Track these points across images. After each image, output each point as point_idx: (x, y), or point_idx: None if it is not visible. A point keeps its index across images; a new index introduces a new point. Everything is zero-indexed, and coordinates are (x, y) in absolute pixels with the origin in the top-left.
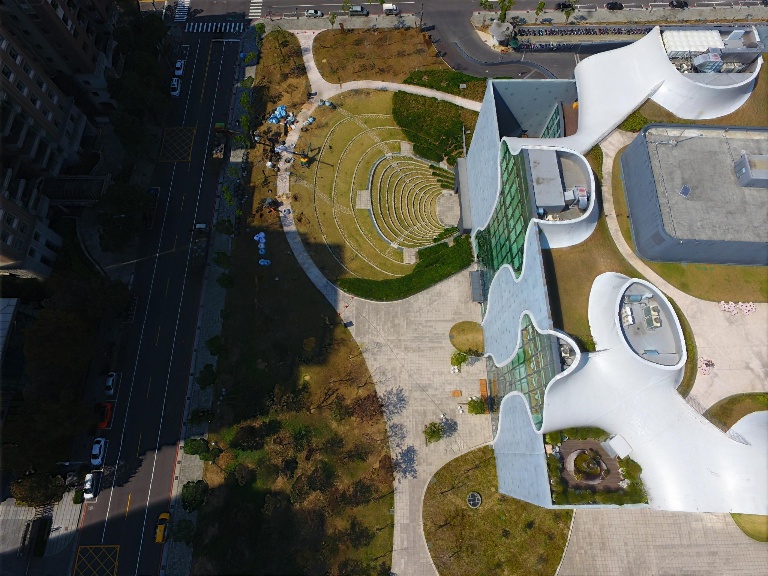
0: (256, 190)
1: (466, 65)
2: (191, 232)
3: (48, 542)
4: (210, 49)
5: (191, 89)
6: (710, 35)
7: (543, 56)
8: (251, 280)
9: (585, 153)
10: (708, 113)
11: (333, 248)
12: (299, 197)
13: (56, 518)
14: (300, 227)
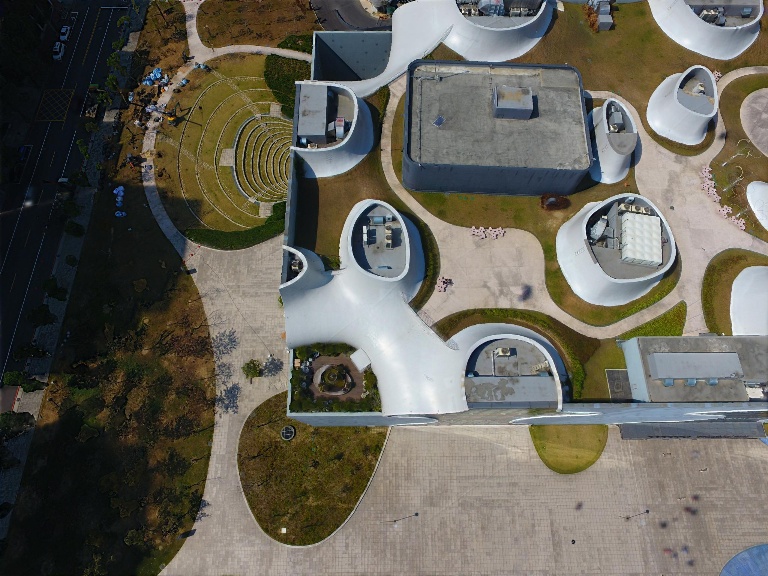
0: (123, 147)
1: None
2: (57, 187)
3: None
4: (98, 16)
5: (75, 53)
6: None
7: None
8: (107, 231)
9: (372, 93)
10: (496, 56)
11: (191, 202)
12: (163, 154)
13: None
14: (159, 181)
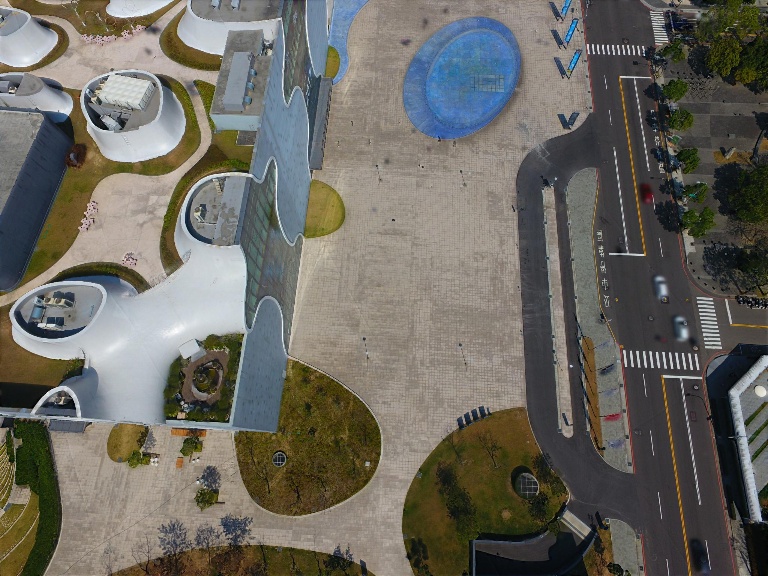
0: None
1: None
2: None
3: None
4: None
5: None
6: None
7: None
8: None
9: None
10: None
11: None
12: None
13: None
14: None
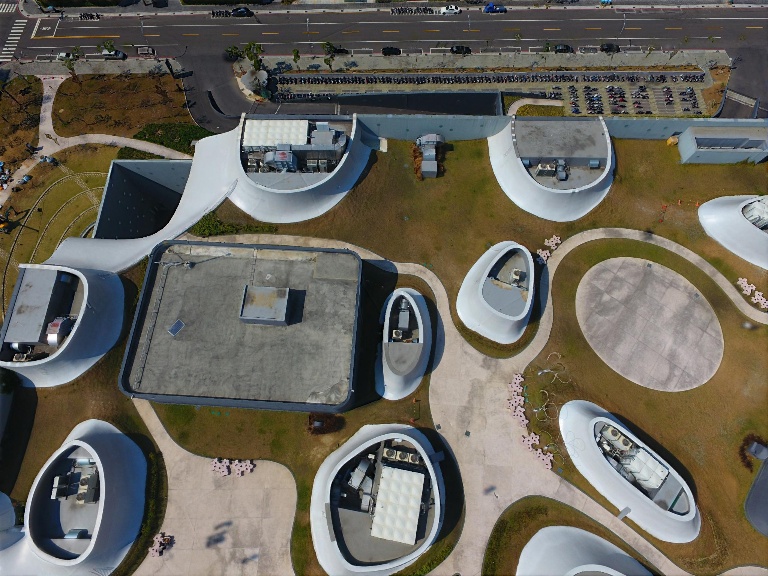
0: None
1: (211, 117)
2: None
3: None
4: None
5: None
6: (295, 126)
7: (300, 107)
8: None
9: (135, 263)
10: (291, 216)
11: None
12: None
13: None
14: None
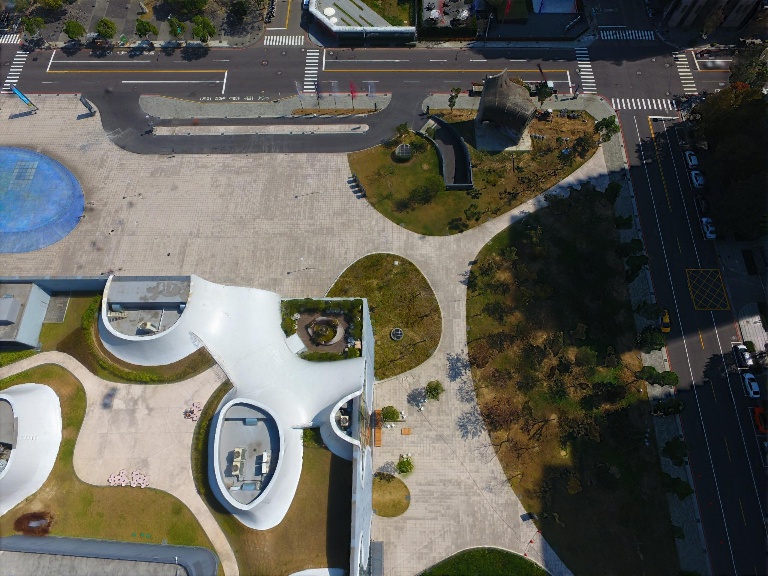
0: None
1: None
2: None
3: (759, 313)
4: None
5: None
6: None
7: None
8: None
9: None
10: None
11: None
12: None
13: (761, 330)
14: None
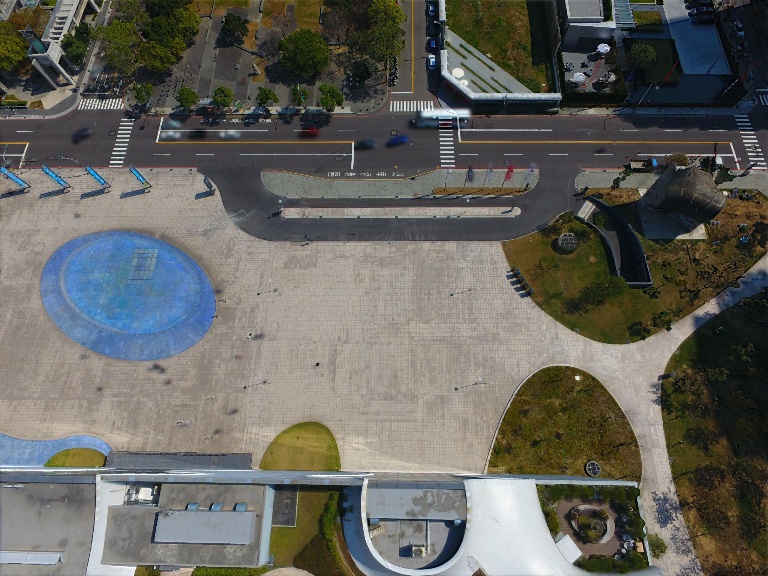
0: None
1: None
2: None
3: None
4: None
5: None
6: None
7: None
8: None
9: None
10: None
11: None
12: None
13: None
14: None
